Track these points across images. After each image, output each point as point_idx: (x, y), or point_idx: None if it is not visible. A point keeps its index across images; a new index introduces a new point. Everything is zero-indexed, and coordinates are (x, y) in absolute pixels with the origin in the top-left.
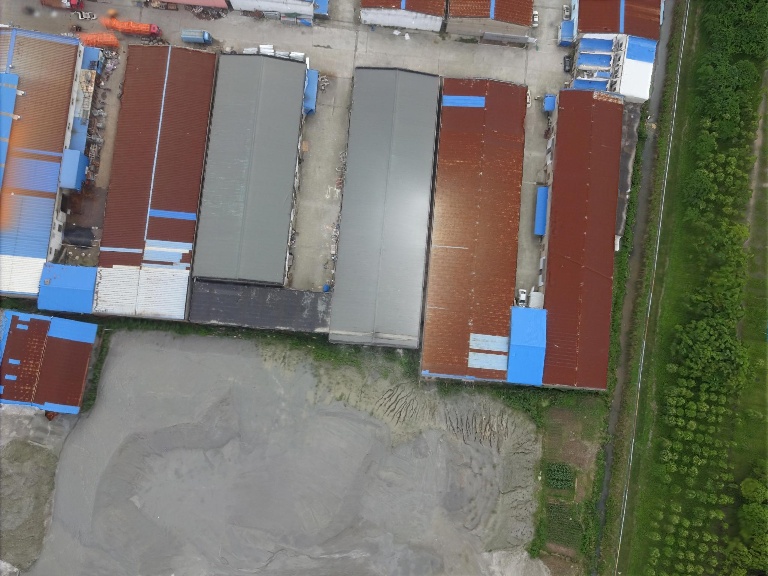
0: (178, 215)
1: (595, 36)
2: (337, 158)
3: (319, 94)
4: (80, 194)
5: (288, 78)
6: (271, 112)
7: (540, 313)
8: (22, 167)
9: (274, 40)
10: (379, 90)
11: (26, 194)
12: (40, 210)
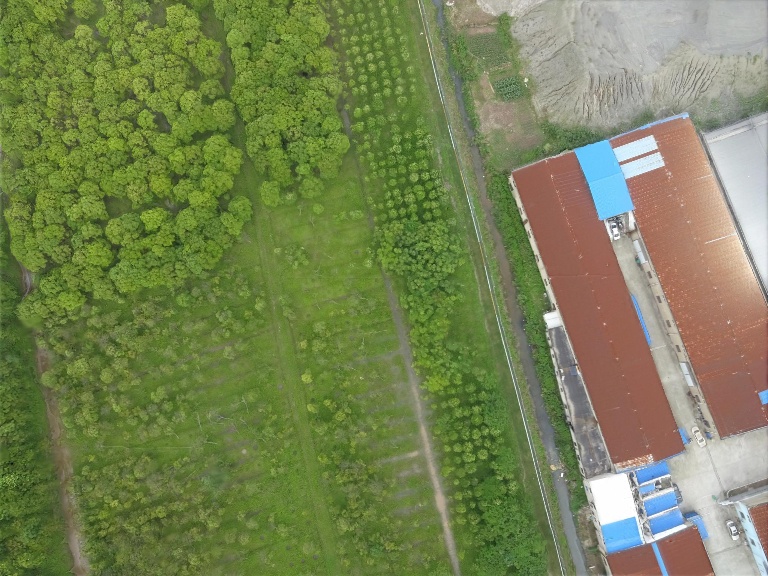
0: None
1: None
2: None
3: None
4: None
5: None
6: None
7: (607, 213)
8: None
9: None
10: None
11: None
12: None
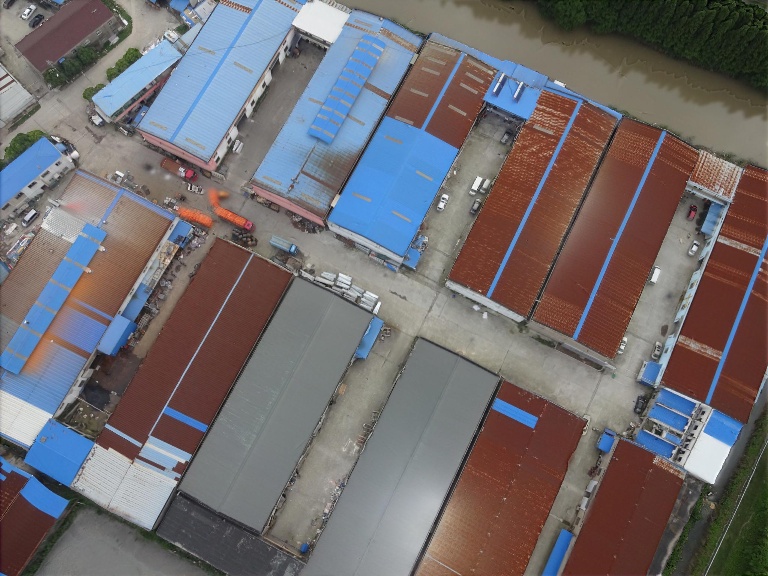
0: (191, 421)
1: (678, 393)
2: (369, 413)
3: (376, 343)
4: (115, 356)
5: (350, 324)
6: (320, 352)
7: None
8: (72, 318)
9: (355, 272)
10: (434, 370)
11: (64, 345)
12: (69, 365)
